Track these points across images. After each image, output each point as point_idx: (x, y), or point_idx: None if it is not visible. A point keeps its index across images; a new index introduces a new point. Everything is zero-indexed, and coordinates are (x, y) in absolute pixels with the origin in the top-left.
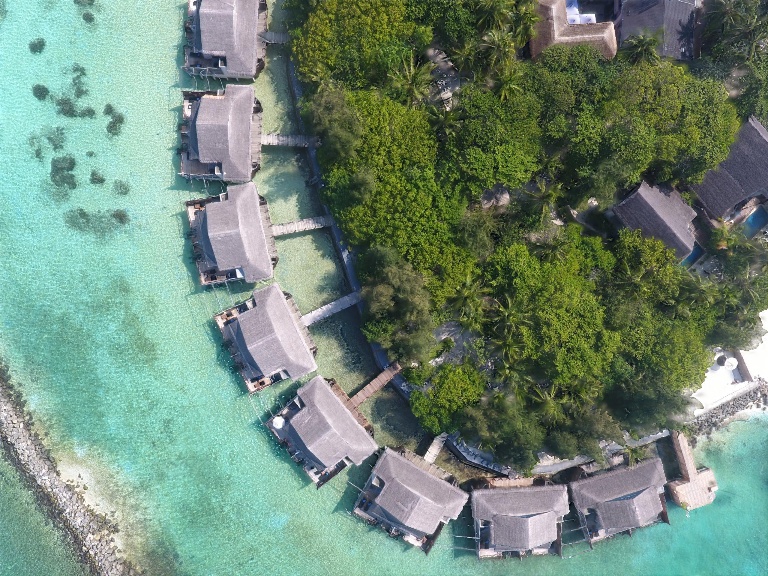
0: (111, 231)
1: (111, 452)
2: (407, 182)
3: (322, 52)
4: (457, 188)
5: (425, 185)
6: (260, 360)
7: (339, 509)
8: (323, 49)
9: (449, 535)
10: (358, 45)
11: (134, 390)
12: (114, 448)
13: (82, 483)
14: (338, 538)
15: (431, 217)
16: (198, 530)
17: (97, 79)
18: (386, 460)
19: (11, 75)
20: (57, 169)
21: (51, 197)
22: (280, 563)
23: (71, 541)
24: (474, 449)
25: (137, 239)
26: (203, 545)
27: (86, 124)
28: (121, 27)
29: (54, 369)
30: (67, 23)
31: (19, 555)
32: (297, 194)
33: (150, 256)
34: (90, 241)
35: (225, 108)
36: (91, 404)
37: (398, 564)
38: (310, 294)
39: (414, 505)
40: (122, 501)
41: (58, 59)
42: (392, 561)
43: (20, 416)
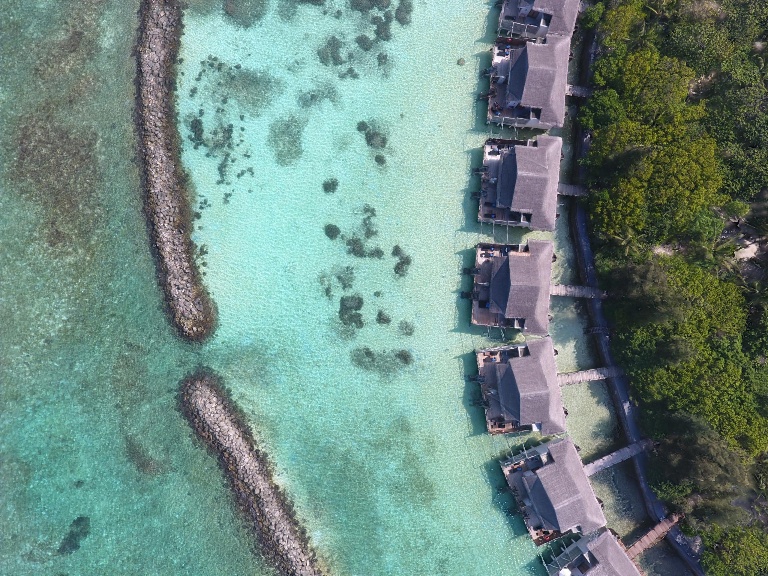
0: (395, 371)
1: None
2: (711, 349)
3: (633, 217)
4: (767, 361)
5: (734, 356)
6: (562, 518)
7: None
8: (634, 215)
9: None
10: (672, 214)
11: (412, 529)
12: None
13: None
14: None
15: (740, 388)
16: None
17: (387, 220)
18: None
19: (305, 214)
20: (346, 308)
21: (339, 335)
22: None
23: None
24: None
25: (420, 380)
26: None
27: (375, 264)
28: (411, 170)
29: (336, 506)
30: (359, 164)
31: None
32: (575, 341)
33: (432, 397)
34: (375, 380)
35: (534, 267)
36: (370, 541)
37: None
38: (584, 440)
39: None
40: None
41: (350, 199)
42: None
43: (306, 553)
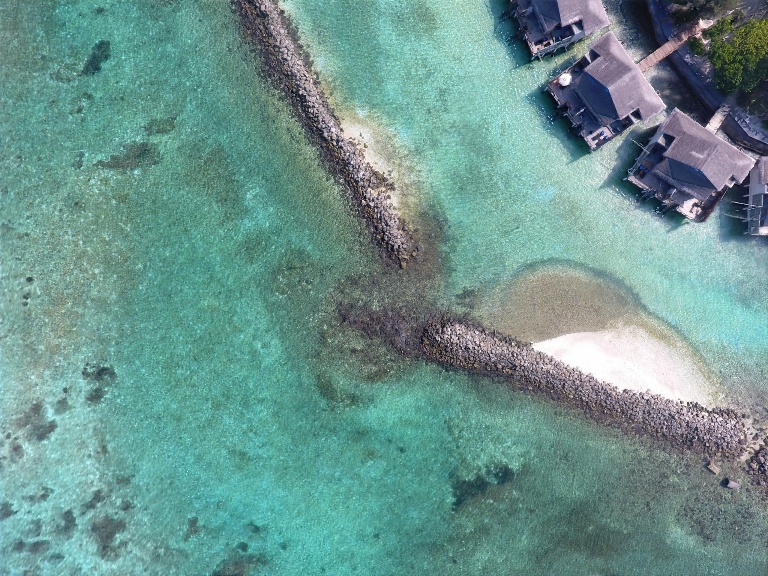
0: None
1: (389, 116)
2: None
3: None
4: None
5: None
6: (562, 2)
7: (606, 185)
8: None
9: (715, 219)
10: None
11: (413, 58)
12: (392, 113)
13: (363, 142)
14: (603, 214)
15: None
16: (467, 197)
17: None
18: (675, 117)
19: None
20: None
21: None
22: (544, 234)
23: (350, 196)
24: (755, 127)
25: None
26: (471, 211)
27: None
28: None
29: (339, 34)
30: None
31: (301, 207)
32: None
33: None
34: None
35: None
36: (372, 70)
37: (661, 244)
38: None
39: (711, 151)
40: (398, 162)
41: None
42: (655, 241)
43: (309, 73)
